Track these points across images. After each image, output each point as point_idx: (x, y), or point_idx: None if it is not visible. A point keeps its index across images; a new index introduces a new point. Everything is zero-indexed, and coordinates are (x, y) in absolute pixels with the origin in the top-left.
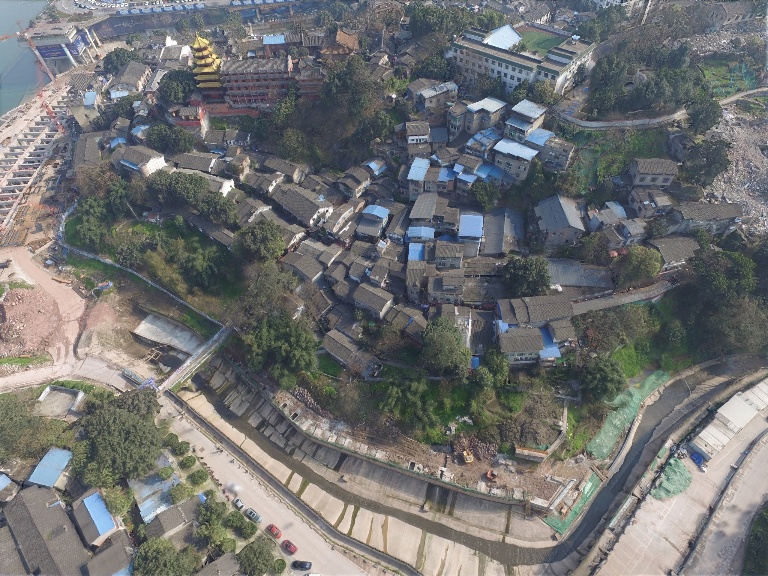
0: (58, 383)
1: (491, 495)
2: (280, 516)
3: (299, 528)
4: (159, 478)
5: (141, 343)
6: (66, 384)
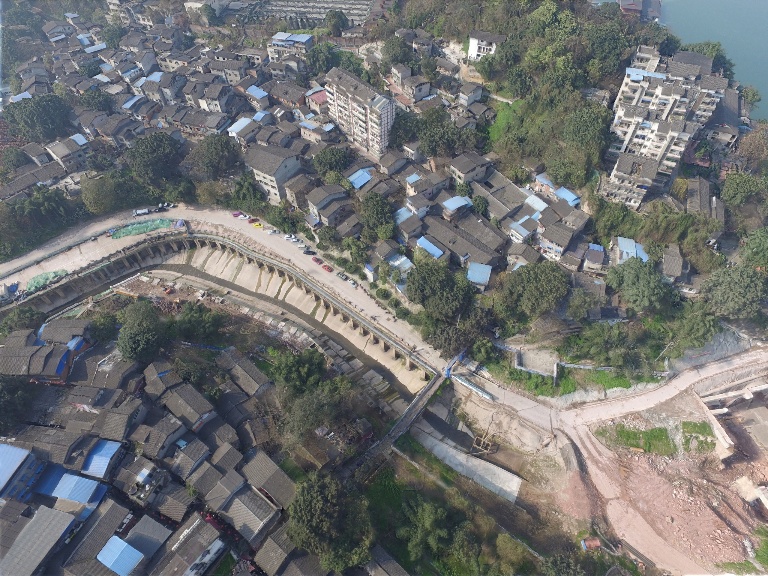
0: (548, 378)
1: (175, 281)
2: (324, 277)
3: (311, 270)
4: (405, 280)
5: (509, 470)
6: (538, 375)
